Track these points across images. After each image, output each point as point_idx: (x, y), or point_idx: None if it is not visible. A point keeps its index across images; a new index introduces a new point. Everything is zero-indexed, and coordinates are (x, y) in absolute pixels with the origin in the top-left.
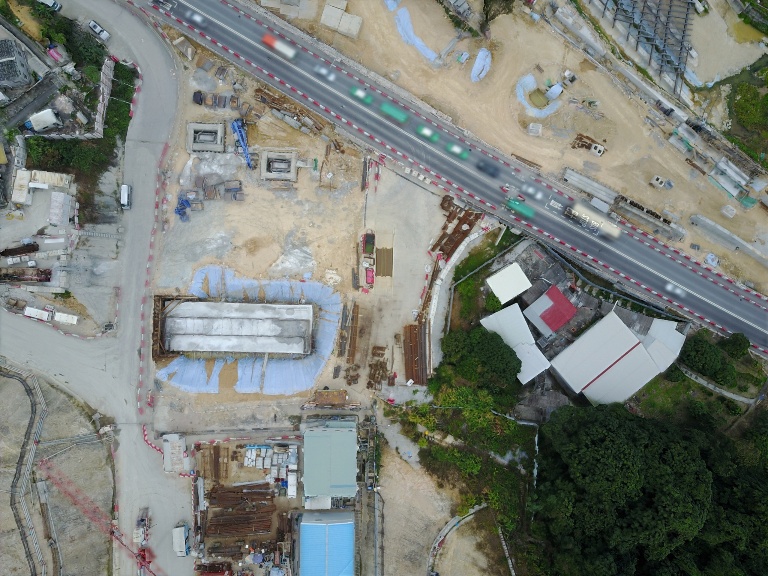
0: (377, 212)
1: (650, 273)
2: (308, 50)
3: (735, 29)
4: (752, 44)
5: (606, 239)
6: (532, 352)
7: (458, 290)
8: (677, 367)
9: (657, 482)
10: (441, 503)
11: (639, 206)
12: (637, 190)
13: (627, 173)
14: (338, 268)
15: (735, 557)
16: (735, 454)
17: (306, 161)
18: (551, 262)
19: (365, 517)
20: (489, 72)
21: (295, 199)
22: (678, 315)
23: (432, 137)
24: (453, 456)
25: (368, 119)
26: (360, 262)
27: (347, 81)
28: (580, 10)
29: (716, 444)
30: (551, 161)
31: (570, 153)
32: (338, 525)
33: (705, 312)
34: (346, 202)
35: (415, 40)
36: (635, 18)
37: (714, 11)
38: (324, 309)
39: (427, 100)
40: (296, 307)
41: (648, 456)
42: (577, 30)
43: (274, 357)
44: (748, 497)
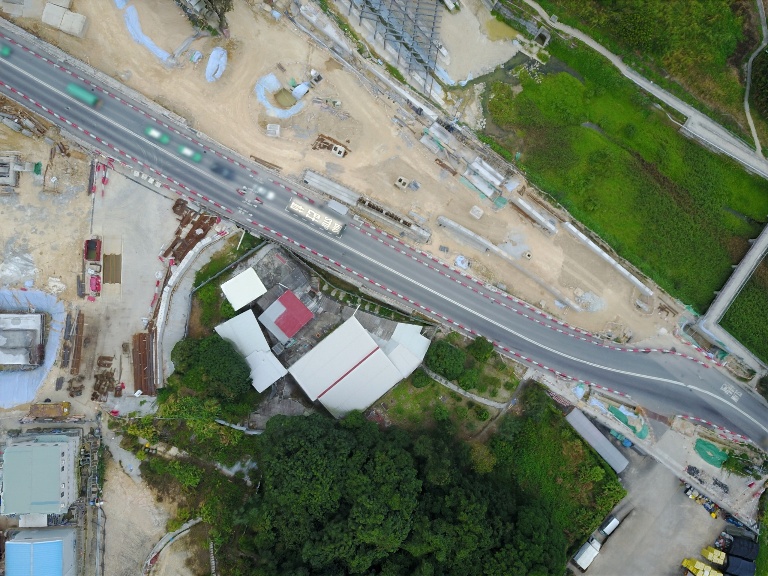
0: (105, 217)
1: (397, 276)
2: (30, 50)
3: (488, 26)
4: (505, 42)
5: (350, 242)
6: (267, 359)
7: (197, 296)
8: (422, 372)
9: (354, 493)
10: (158, 518)
11: (378, 208)
12: (382, 191)
13: (371, 174)
14: (62, 275)
15: (438, 568)
16: (470, 461)
17: (24, 165)
18: (293, 266)
19: (90, 534)
20: (226, 72)
21: (17, 204)
22: (426, 319)
23: (164, 139)
24: (174, 469)
25: (96, 121)
26: (86, 269)
27: (73, 82)
28: (324, 8)
29: (444, 451)
30: (292, 163)
31: (312, 154)
32: (44, 543)
33: (455, 315)
34: (71, 207)
35: (144, 39)
36: (384, 16)
37: (465, 8)
38: (53, 318)
39: (160, 101)
40: (22, 316)
41: (350, 466)
42: (322, 28)
43: (3, 369)
44: (458, 506)
